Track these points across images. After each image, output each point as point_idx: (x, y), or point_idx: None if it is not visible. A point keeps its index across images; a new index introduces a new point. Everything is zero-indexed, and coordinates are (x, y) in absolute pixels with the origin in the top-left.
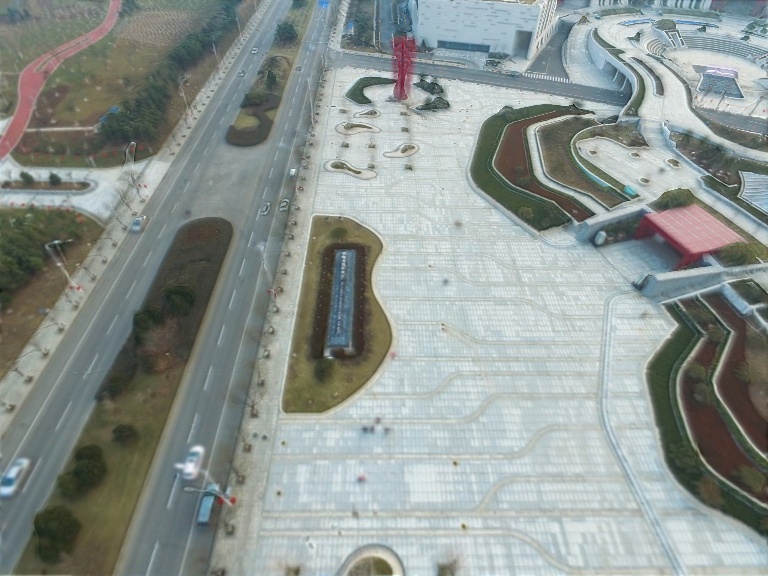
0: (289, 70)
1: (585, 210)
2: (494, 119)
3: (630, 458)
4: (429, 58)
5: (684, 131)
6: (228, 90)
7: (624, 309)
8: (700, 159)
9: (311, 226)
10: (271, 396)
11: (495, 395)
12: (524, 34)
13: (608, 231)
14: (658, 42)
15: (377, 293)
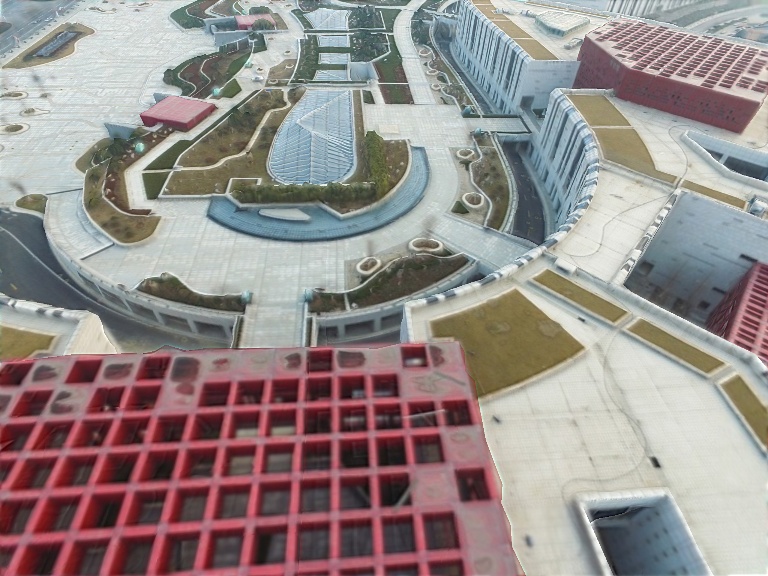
0: None
1: None
2: None
3: (151, 78)
4: None
5: None
6: None
7: (200, 49)
8: (303, 4)
9: (58, 26)
10: None
11: None
12: None
13: (218, 25)
14: None
15: (76, 44)
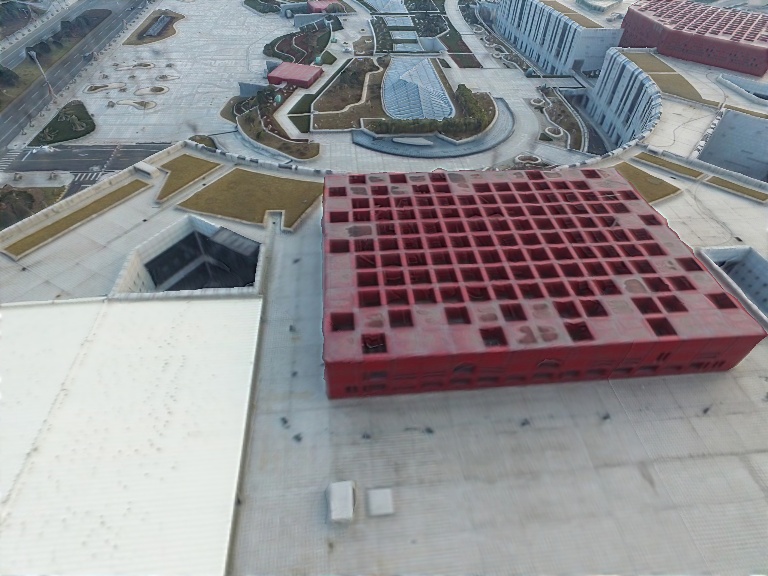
0: None
1: None
2: None
3: (252, 52)
4: None
5: None
6: None
7: (282, 29)
8: None
9: (152, 12)
10: (118, 43)
11: None
12: None
13: (292, 10)
14: None
15: (175, 26)
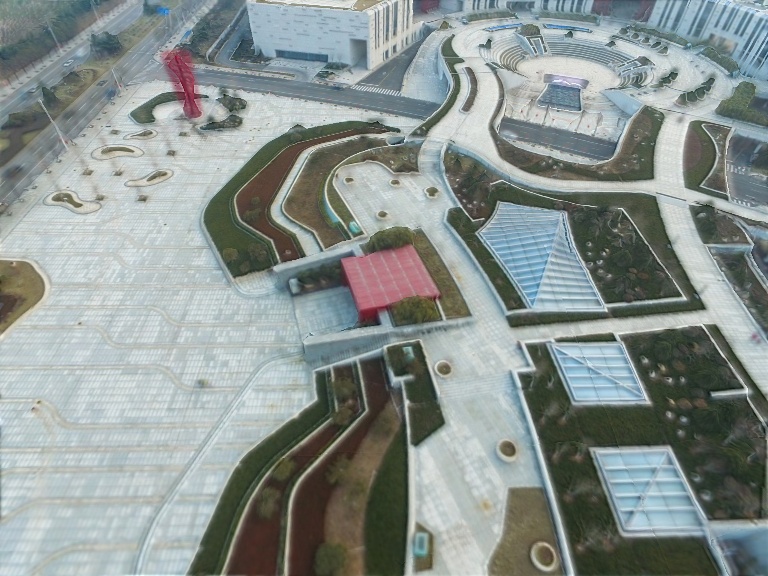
0: (89, 85)
1: (299, 251)
2: (280, 139)
3: None
4: (260, 69)
5: (468, 153)
6: (5, 108)
7: (270, 378)
8: (461, 187)
9: None
10: None
11: (34, 501)
12: (359, 43)
13: (303, 278)
14: (519, 49)
15: None
